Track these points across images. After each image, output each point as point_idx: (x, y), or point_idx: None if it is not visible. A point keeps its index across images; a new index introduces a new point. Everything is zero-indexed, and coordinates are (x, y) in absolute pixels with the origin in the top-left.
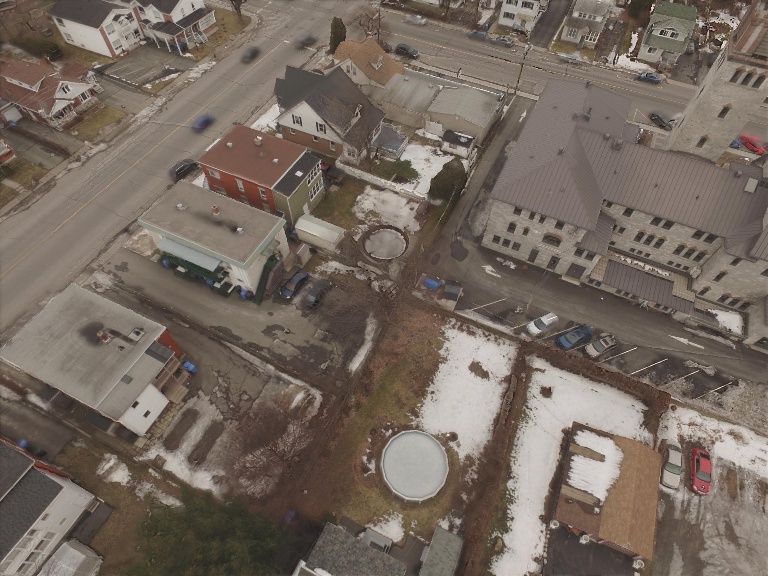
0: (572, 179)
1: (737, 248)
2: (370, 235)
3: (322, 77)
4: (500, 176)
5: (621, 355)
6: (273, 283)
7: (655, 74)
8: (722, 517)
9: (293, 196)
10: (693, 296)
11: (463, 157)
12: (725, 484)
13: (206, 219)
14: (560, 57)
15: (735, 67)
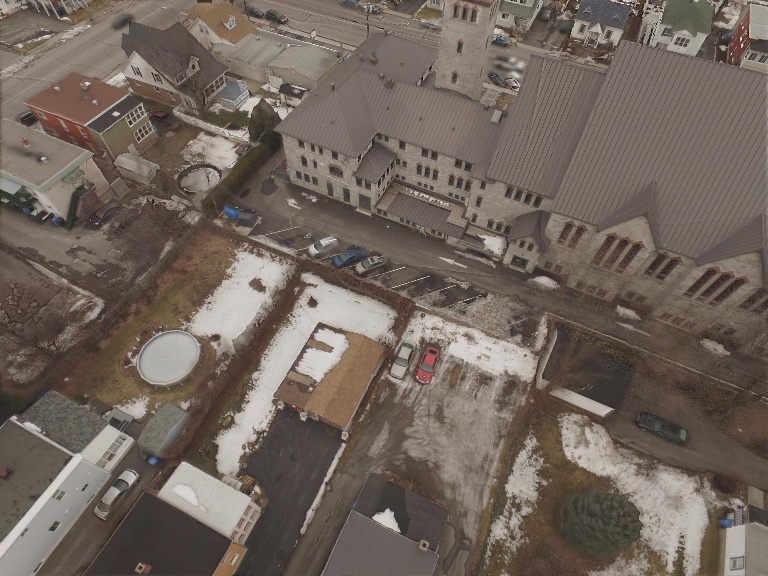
0: (341, 112)
1: (478, 171)
2: (189, 173)
3: (159, 31)
4: None
5: (389, 273)
6: (85, 211)
7: (504, 37)
8: (436, 401)
9: (109, 134)
10: (465, 223)
11: None
12: (448, 376)
13: (17, 151)
14: (422, 23)
15: (452, 3)
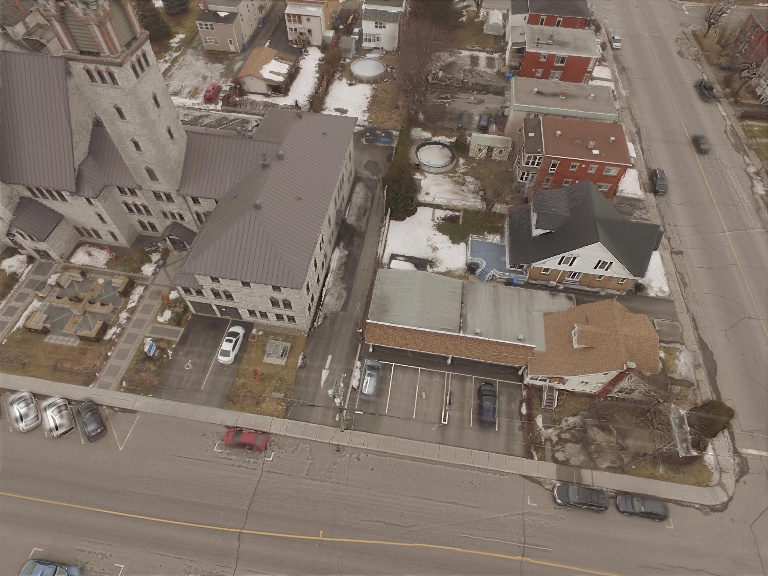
0: None
1: None
2: (451, 160)
3: (602, 218)
4: None
5: None
6: None
7: (34, 574)
8: (207, 82)
9: None
10: None
11: None
12: (199, 92)
13: (566, 95)
14: None
15: None
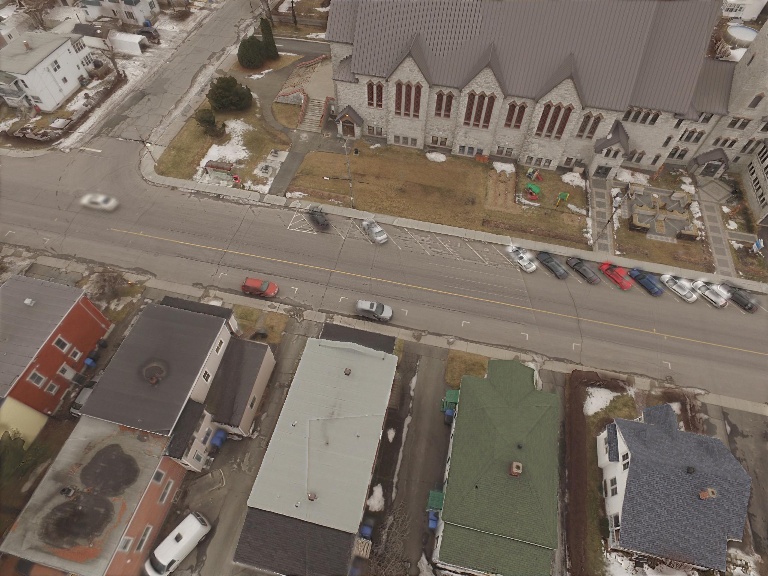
0: None
1: None
2: None
3: None
4: None
5: None
6: None
7: None
8: None
9: None
10: None
11: None
12: None
13: None
14: None
15: None
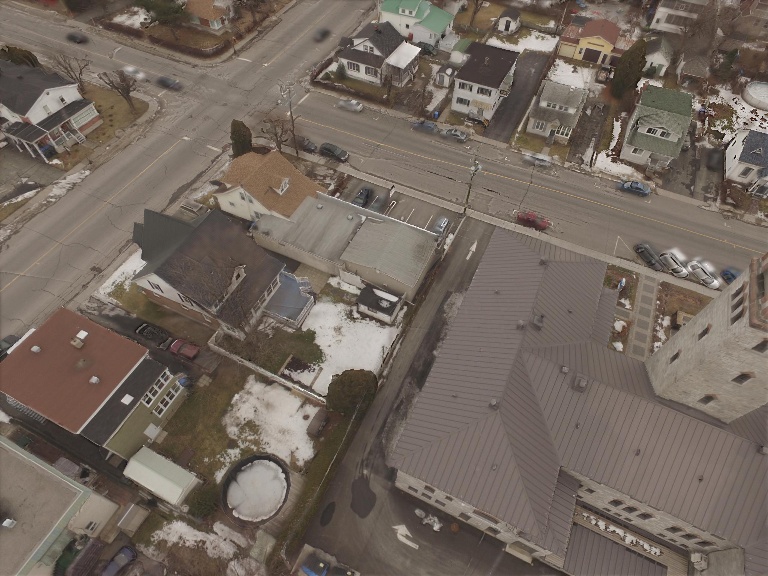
0: (509, 452)
1: None
2: (238, 473)
3: (188, 228)
4: (409, 421)
5: None
6: None
7: (642, 185)
8: None
9: (116, 435)
10: None
11: (386, 323)
12: None
13: None
14: (524, 156)
15: (762, 336)
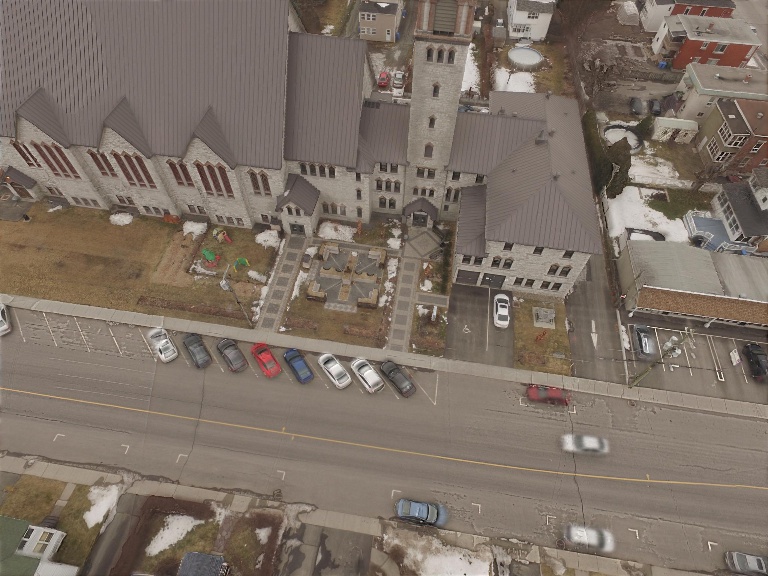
0: None
1: None
2: (639, 142)
3: None
4: None
5: None
6: None
7: (414, 511)
8: None
9: None
10: None
11: None
12: None
13: None
14: (611, 551)
15: None
